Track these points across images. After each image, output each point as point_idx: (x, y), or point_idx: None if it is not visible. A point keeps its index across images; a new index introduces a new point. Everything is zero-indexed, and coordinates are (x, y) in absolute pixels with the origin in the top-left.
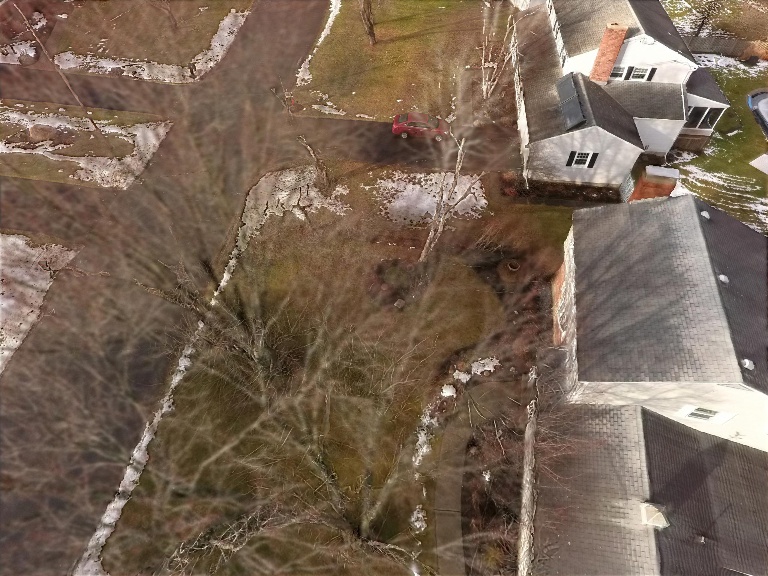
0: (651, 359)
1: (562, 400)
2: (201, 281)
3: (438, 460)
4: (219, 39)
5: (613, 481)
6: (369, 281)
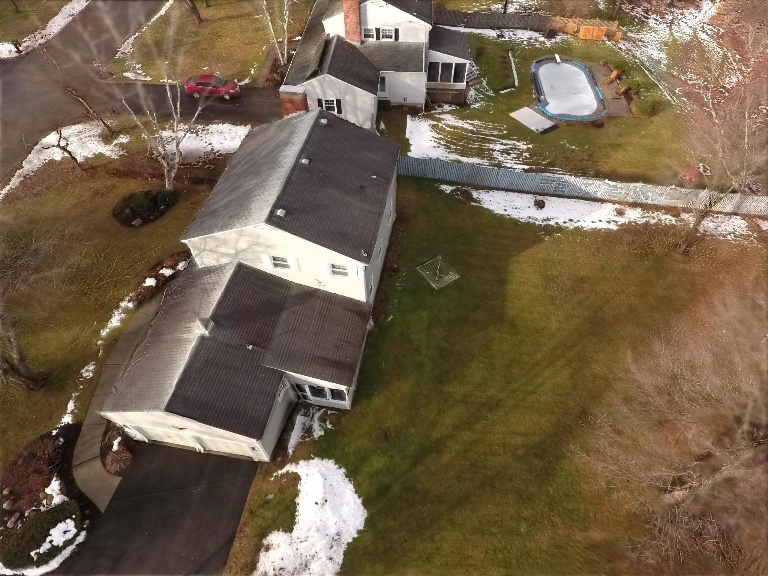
0: (227, 218)
1: (196, 267)
2: None
3: (121, 331)
4: (56, 21)
5: (195, 312)
6: (118, 207)
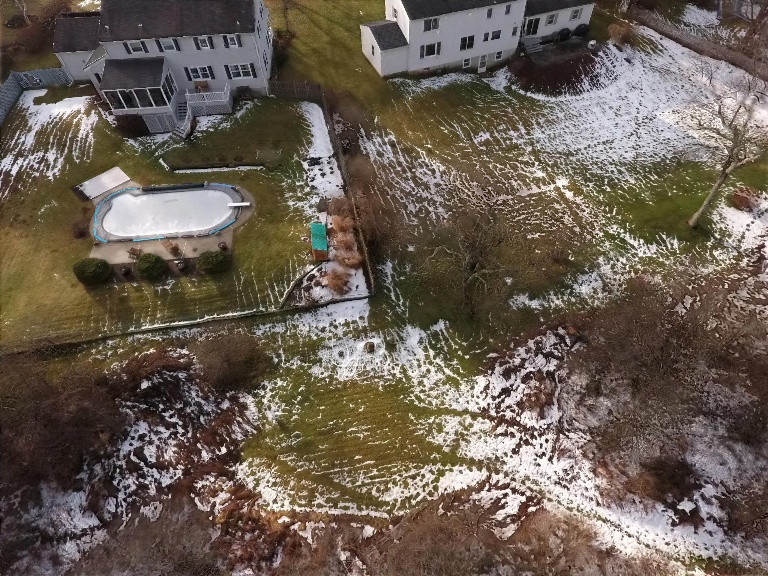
0: None
1: None
2: None
3: None
4: None
5: None
6: None
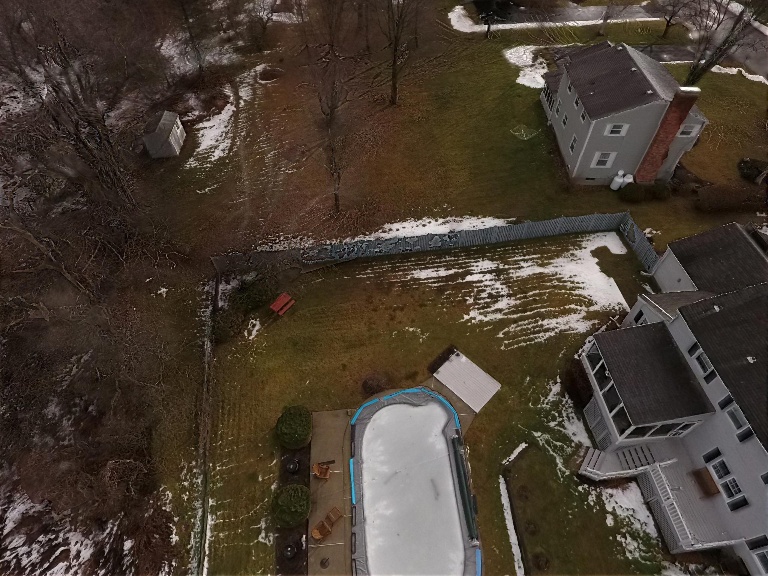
0: (648, 59)
1: None
2: None
3: None
4: None
5: None
6: None
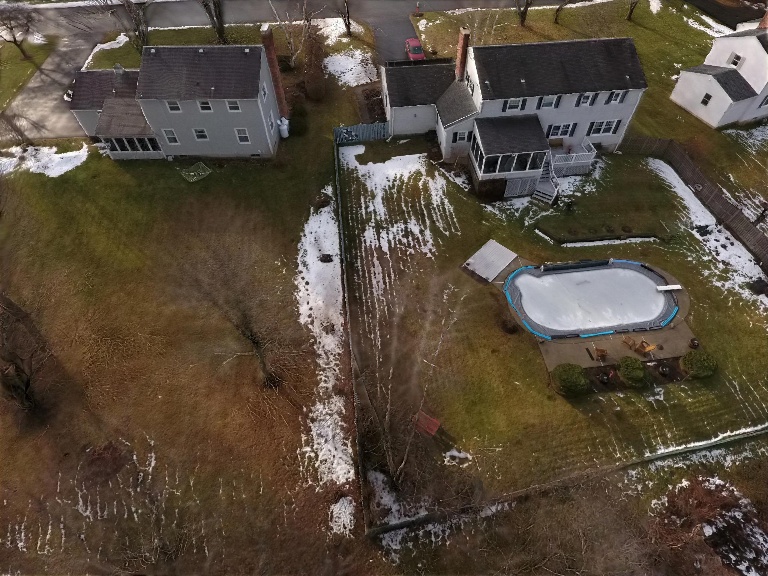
0: None
1: None
2: None
3: None
4: None
5: None
6: None
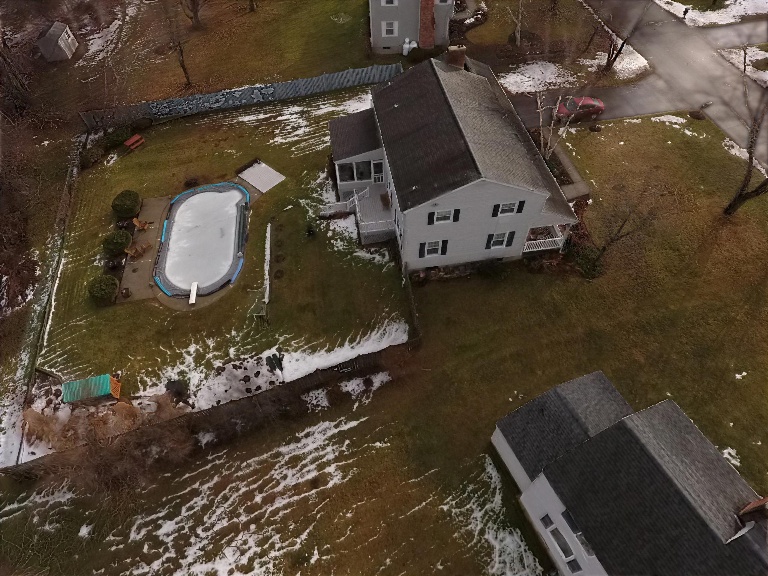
0: None
1: None
2: (616, 26)
3: None
4: None
5: None
6: None
